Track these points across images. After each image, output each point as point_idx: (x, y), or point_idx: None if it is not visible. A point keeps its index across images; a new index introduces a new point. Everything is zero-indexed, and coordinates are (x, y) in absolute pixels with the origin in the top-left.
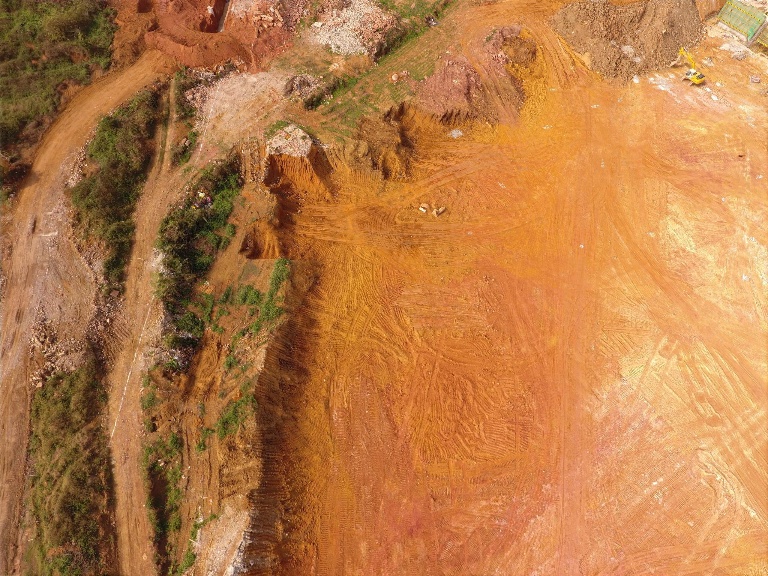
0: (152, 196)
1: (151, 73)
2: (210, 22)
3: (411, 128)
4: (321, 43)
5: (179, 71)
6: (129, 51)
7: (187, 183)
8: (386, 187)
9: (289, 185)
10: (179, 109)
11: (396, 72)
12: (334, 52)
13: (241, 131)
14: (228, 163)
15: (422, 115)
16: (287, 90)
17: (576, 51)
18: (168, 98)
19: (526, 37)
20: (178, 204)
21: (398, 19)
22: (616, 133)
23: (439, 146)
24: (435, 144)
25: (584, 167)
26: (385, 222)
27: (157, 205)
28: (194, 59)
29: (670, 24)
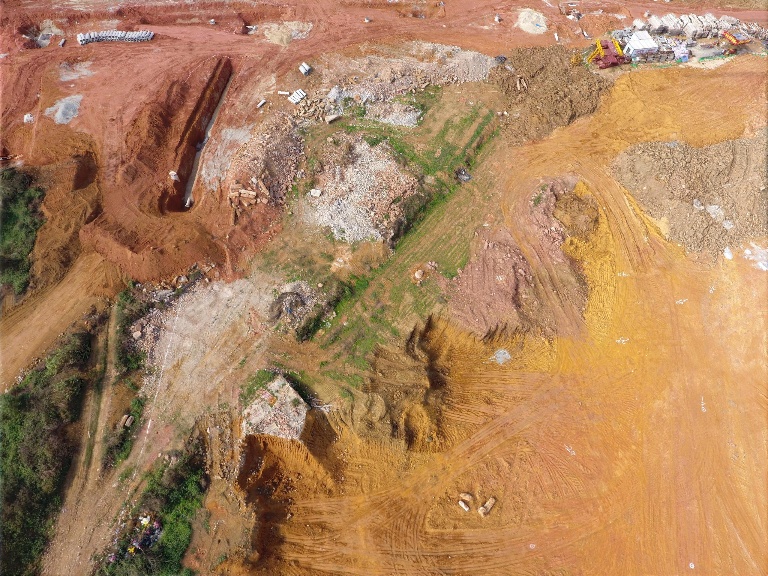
0: (68, 539)
1: (84, 297)
2: (173, 191)
3: (441, 347)
4: (320, 224)
5: (124, 290)
6: (55, 262)
7: (123, 505)
8: (411, 461)
9: (275, 465)
10: (119, 363)
11: (420, 263)
12: (337, 239)
13: (207, 393)
14: (186, 460)
15: (456, 330)
16: (273, 316)
17: (649, 214)
18: (106, 340)
19: (584, 194)
20: (107, 551)
21: (420, 180)
22: (714, 349)
23: (480, 379)
24: (474, 375)
25: (679, 413)
26: (411, 530)
27: (74, 558)
28: (145, 270)
29: (767, 174)
